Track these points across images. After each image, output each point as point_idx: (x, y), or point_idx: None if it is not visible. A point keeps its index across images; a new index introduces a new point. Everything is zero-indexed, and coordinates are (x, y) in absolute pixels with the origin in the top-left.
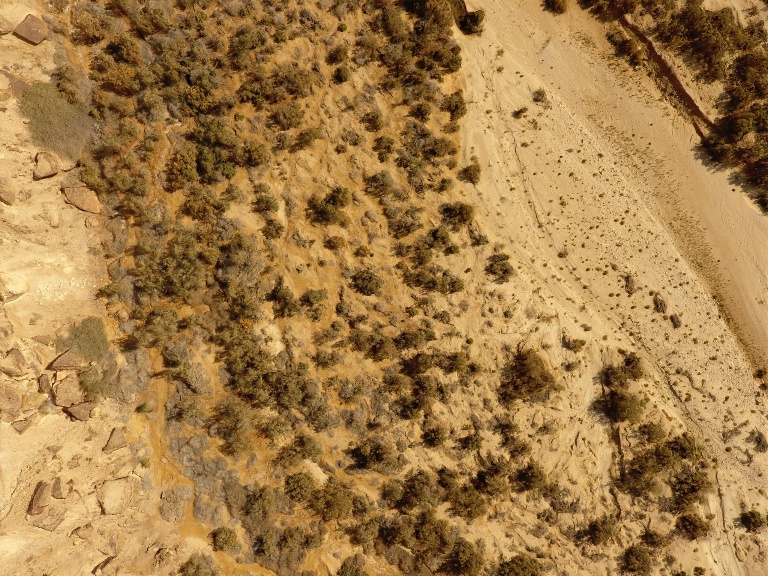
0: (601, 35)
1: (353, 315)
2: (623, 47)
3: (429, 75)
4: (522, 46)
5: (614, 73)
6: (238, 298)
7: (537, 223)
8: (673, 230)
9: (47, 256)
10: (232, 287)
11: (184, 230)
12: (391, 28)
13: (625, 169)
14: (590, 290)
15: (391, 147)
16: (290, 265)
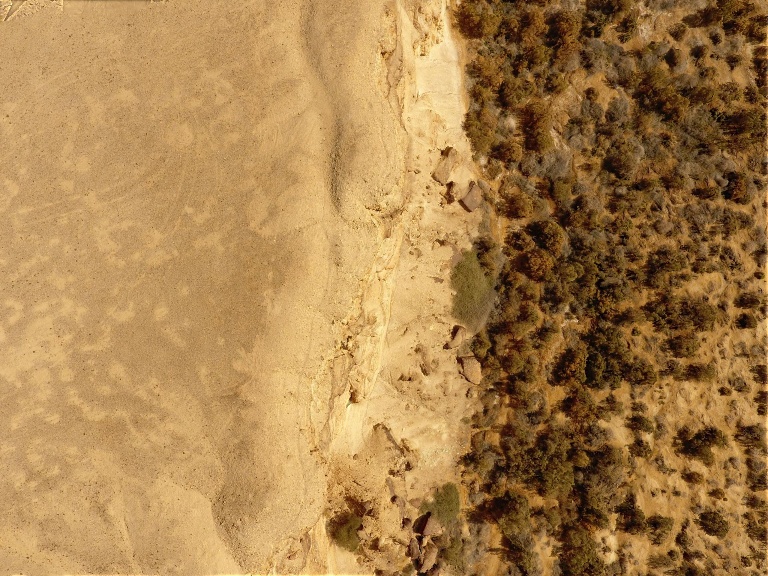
0: None
1: (691, 549)
2: None
3: None
4: None
5: None
6: None
7: None
8: None
9: (434, 422)
10: (592, 496)
11: (557, 426)
12: None
13: None
14: None
15: None
16: (646, 486)
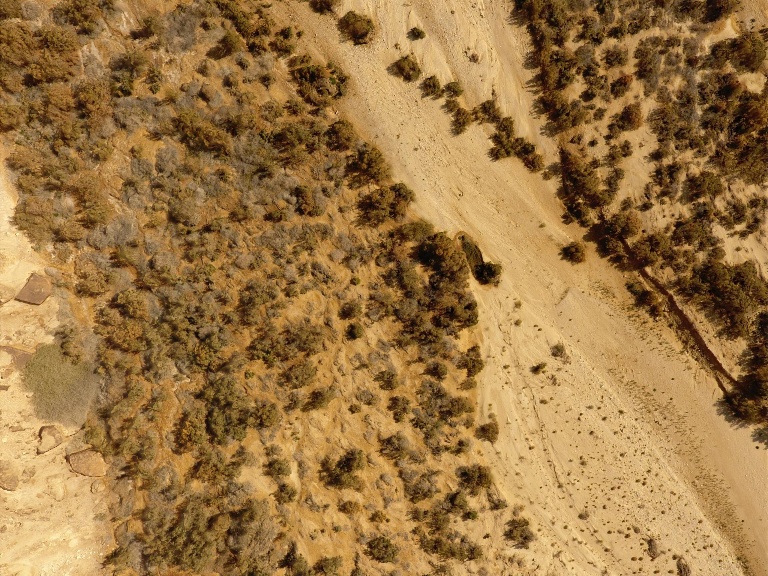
0: (620, 284)
1: None
2: (643, 298)
3: (445, 333)
4: (540, 297)
5: (634, 325)
6: (250, 568)
7: (557, 483)
8: (696, 489)
9: (52, 533)
10: (244, 559)
11: (193, 495)
12: (406, 283)
13: (646, 425)
14: (612, 553)
15: (407, 408)
16: (303, 531)
